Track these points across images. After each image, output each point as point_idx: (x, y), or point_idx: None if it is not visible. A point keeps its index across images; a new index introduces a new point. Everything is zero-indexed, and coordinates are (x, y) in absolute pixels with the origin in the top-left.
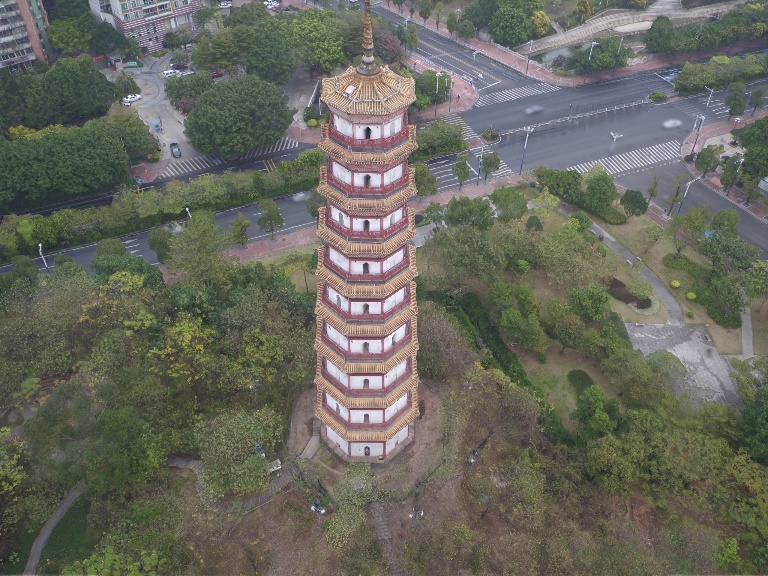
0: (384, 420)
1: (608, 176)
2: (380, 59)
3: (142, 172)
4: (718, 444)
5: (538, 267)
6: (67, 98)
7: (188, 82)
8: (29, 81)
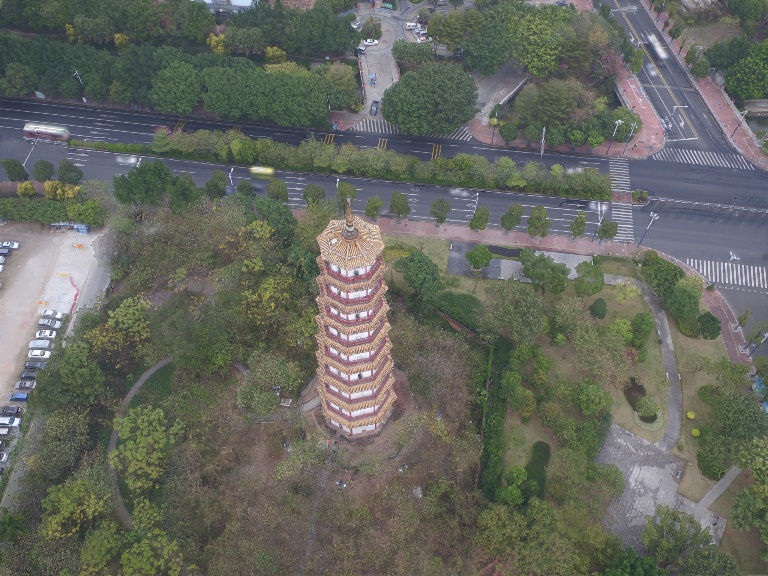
0: (351, 415)
1: (694, 293)
2: (580, 83)
3: (341, 119)
4: (576, 559)
5: (571, 347)
6: (314, 36)
7: (410, 50)
8: (293, 13)
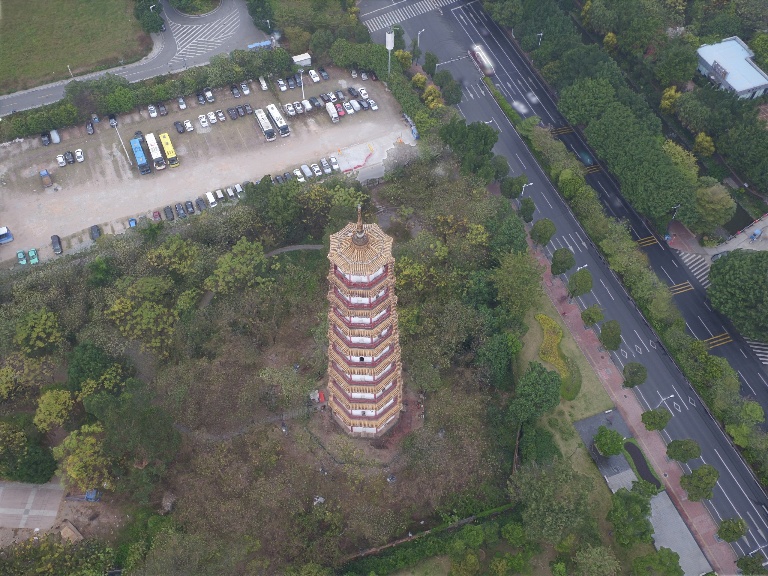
0: None
1: None
2: None
3: (683, 237)
4: None
5: None
6: (747, 155)
7: None
8: (754, 123)
